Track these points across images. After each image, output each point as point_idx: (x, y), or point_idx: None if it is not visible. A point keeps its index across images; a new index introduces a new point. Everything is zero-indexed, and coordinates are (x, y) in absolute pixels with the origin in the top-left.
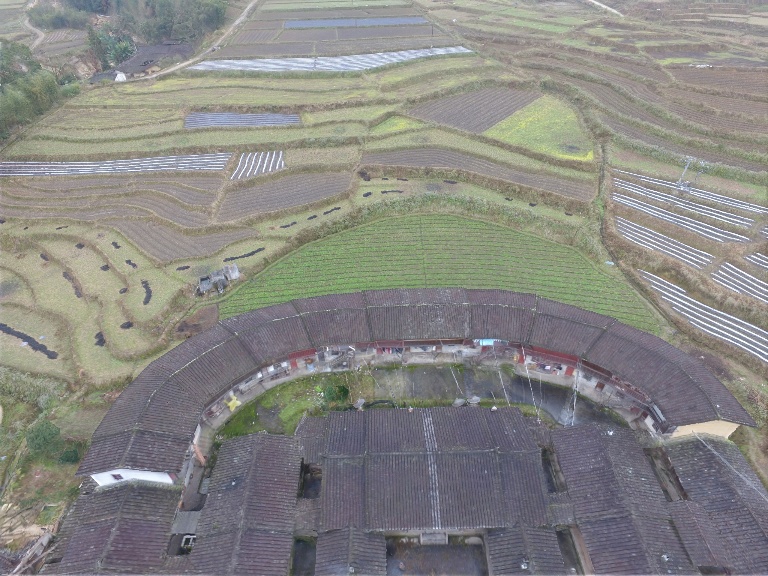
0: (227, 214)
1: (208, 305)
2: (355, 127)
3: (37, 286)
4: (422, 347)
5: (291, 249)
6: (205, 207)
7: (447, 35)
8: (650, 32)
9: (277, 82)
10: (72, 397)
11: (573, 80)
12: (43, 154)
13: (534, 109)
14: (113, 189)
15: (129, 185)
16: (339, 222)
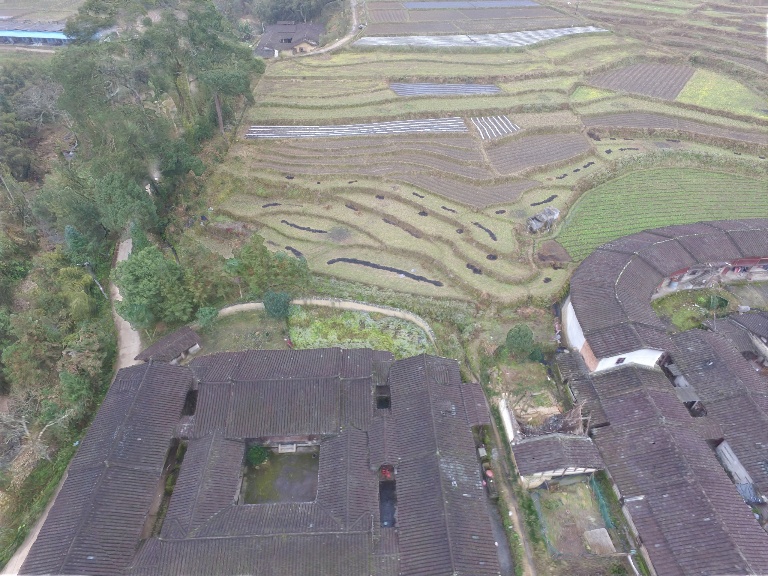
0: (505, 168)
1: (547, 241)
2: (556, 95)
3: (370, 230)
4: (765, 266)
5: (577, 196)
6: (480, 162)
7: (570, 16)
8: (761, 14)
9: (449, 56)
10: (487, 314)
11: (719, 56)
12: (288, 119)
13: (701, 80)
14: (377, 148)
15: (390, 145)
16: (605, 174)
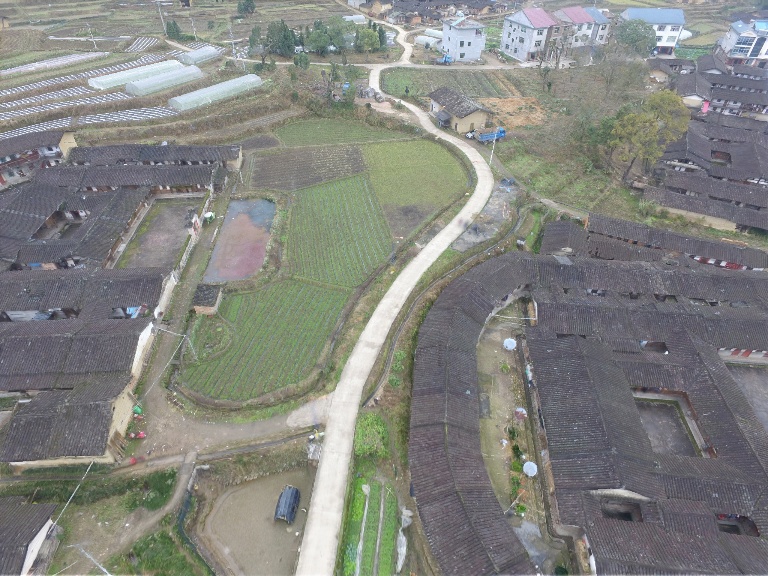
0: None
1: None
2: None
3: None
4: None
5: None
6: None
7: None
8: None
9: None
10: None
11: None
12: None
13: None
14: None
15: None
16: None
